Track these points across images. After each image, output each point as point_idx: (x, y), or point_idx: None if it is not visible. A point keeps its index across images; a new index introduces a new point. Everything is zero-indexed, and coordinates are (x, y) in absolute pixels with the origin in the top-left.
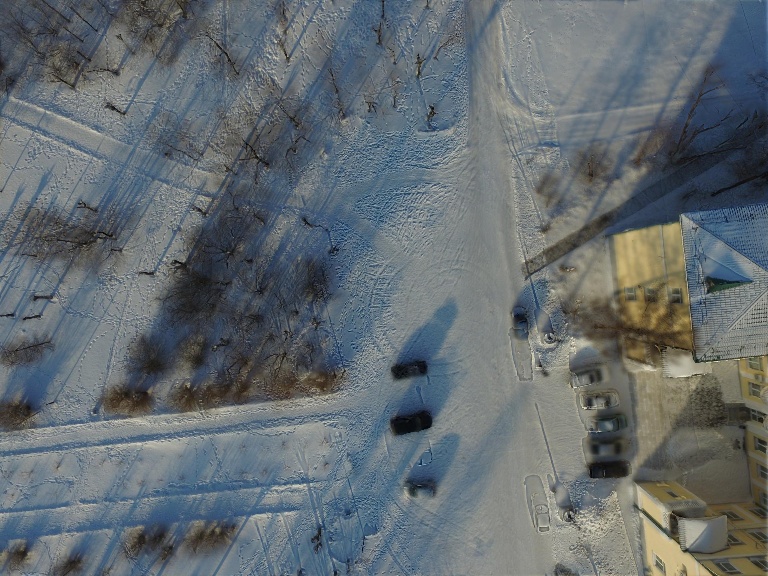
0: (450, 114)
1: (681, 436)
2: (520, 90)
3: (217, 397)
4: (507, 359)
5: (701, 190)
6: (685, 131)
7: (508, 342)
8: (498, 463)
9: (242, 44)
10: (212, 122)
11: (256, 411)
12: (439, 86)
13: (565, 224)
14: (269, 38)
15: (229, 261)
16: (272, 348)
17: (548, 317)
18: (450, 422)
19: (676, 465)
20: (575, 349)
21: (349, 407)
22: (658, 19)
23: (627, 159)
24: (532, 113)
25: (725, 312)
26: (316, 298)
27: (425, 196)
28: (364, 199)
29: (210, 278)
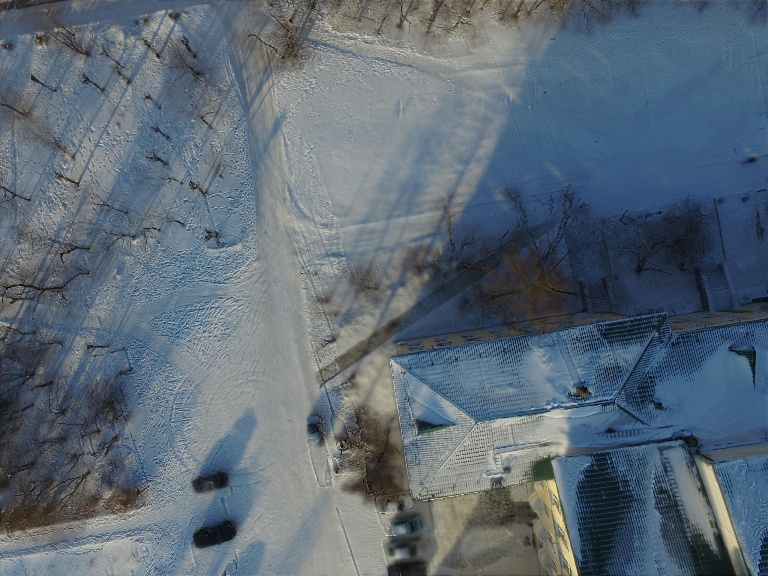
0: (238, 230)
1: (473, 535)
2: (304, 204)
3: (24, 519)
4: (307, 466)
5: (482, 293)
6: (452, 243)
7: (307, 449)
8: (304, 568)
9: (32, 171)
10: (6, 248)
11: (63, 531)
12: (225, 203)
13: (354, 332)
14: (58, 164)
15: (30, 384)
16: (76, 467)
17: (343, 423)
18: (255, 531)
19: (470, 564)
20: (370, 454)
21: (155, 521)
22: (432, 129)
23: (411, 266)
24: (317, 225)
25: (434, 453)
26: (116, 417)
27: (219, 311)
28: (160, 316)
29: (12, 402)
